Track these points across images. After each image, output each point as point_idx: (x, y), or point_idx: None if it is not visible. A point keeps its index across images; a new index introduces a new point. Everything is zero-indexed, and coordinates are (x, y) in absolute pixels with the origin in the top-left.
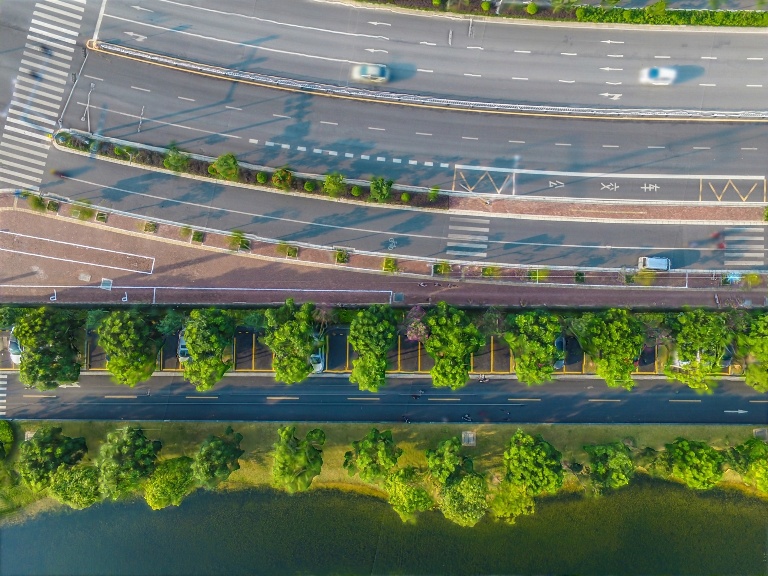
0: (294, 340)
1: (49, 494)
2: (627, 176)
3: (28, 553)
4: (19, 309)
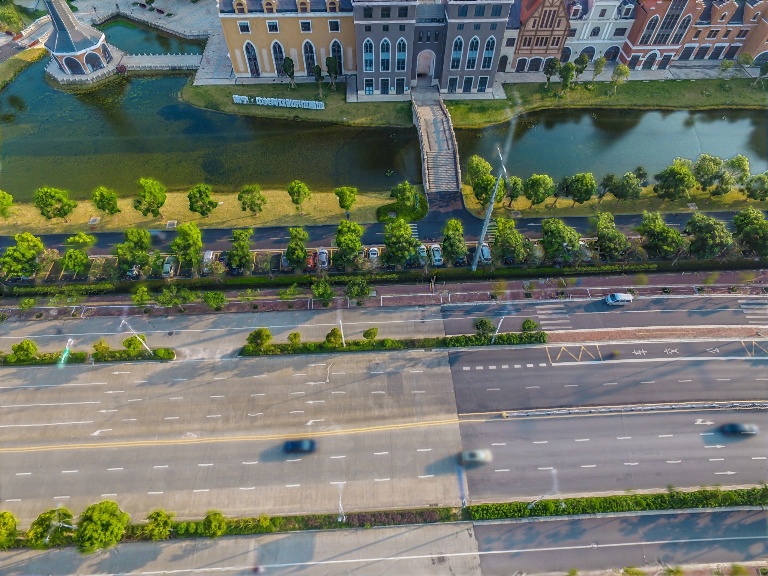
0: None
1: None
2: (662, 359)
3: None
4: None
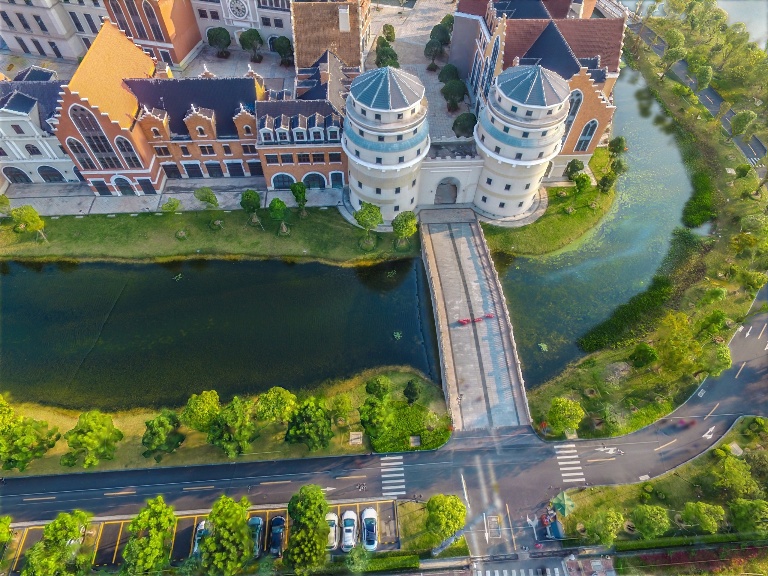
0: (33, 560)
1: (289, 398)
2: None
3: (360, 349)
4: (373, 570)
